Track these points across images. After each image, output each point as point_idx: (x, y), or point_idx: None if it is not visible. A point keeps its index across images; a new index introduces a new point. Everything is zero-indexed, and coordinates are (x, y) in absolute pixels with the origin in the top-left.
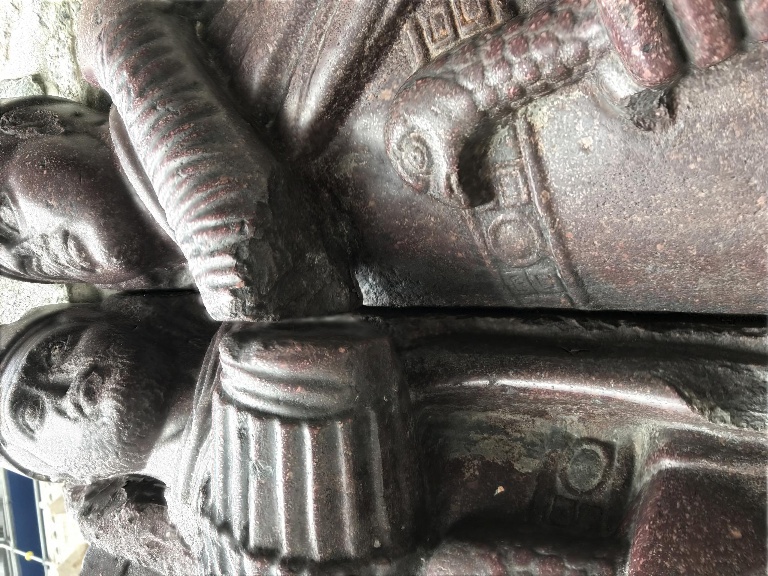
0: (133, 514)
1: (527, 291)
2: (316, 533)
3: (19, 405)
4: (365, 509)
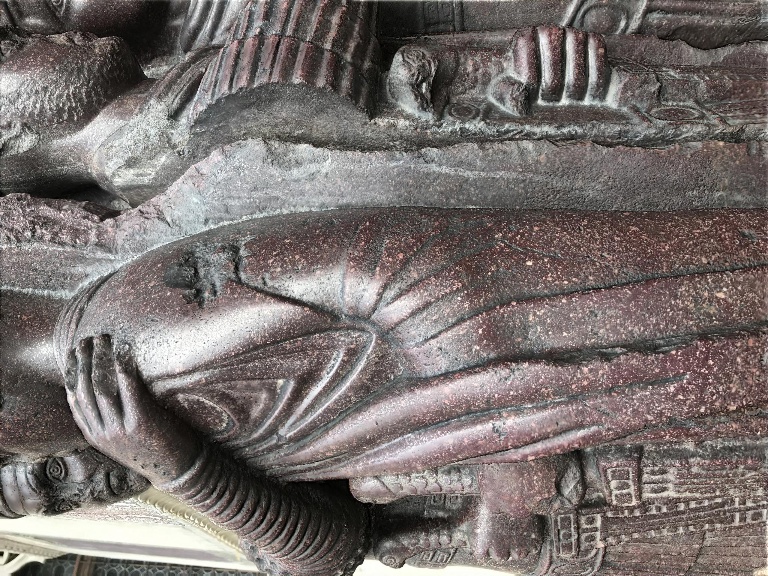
0: (24, 195)
1: (434, 19)
2: None
3: None
4: (369, 8)
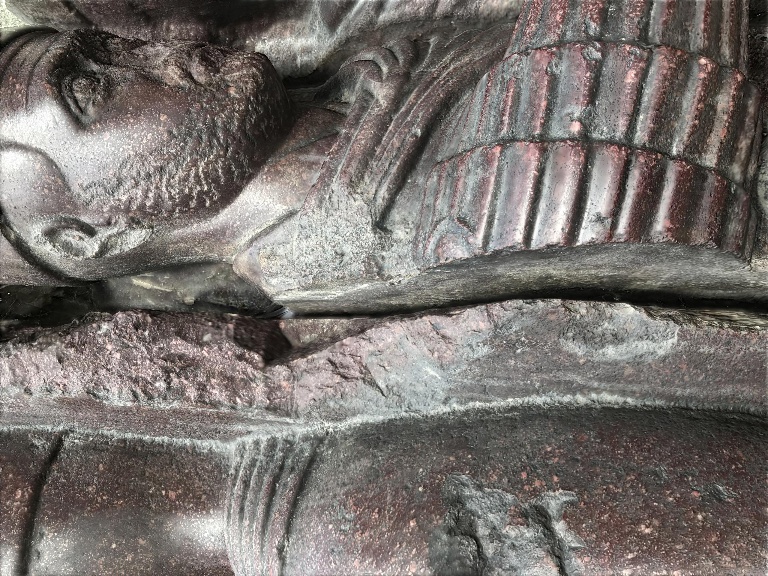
0: (142, 317)
1: None
2: (730, 33)
3: (63, 73)
4: None
